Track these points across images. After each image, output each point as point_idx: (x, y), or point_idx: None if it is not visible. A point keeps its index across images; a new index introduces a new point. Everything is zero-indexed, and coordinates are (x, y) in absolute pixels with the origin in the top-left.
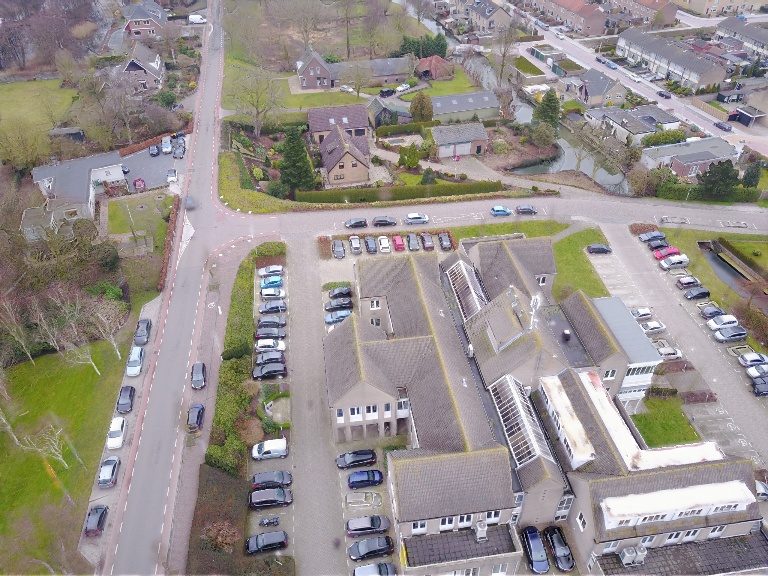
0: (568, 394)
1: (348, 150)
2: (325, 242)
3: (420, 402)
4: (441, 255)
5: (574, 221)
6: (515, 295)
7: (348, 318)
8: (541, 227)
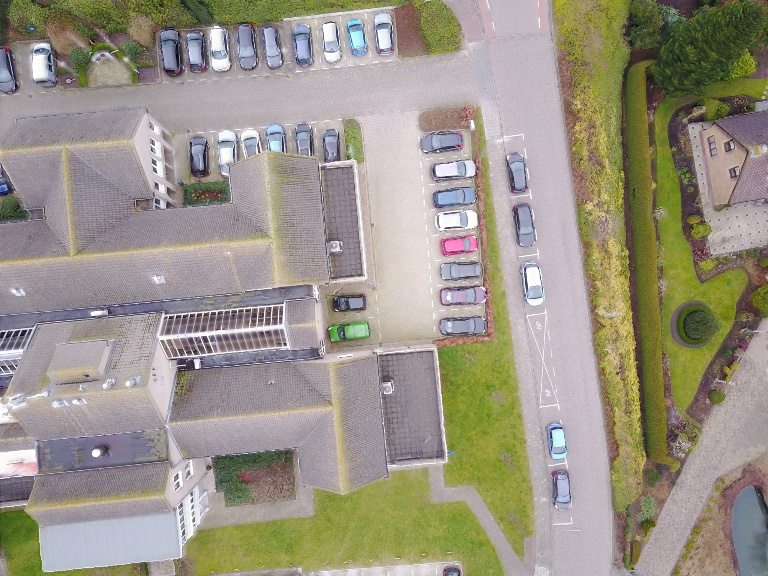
0: (0, 425)
1: (753, 153)
2: (457, 118)
3: (1, 232)
4: (429, 315)
5: (531, 569)
6: (105, 385)
7: (128, 135)
8: (515, 505)
